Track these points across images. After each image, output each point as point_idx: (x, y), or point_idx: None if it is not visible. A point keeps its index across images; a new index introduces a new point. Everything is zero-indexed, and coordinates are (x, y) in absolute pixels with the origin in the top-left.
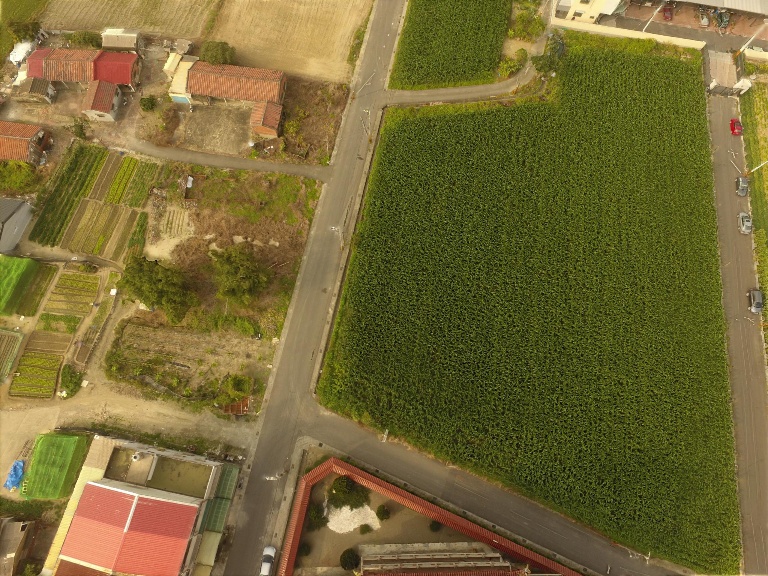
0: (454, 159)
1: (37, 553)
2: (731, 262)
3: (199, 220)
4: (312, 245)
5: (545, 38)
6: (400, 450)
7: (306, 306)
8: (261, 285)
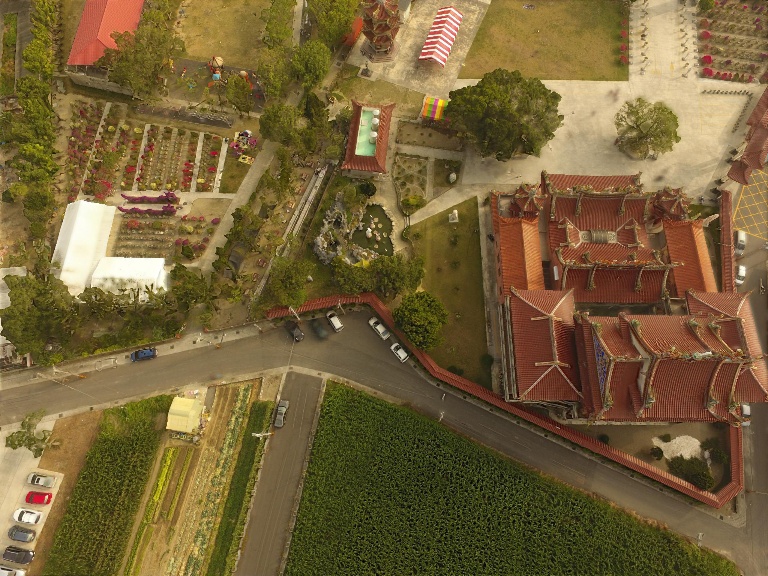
0: None
1: None
2: None
3: None
4: None
5: None
6: (642, 511)
7: None
8: None
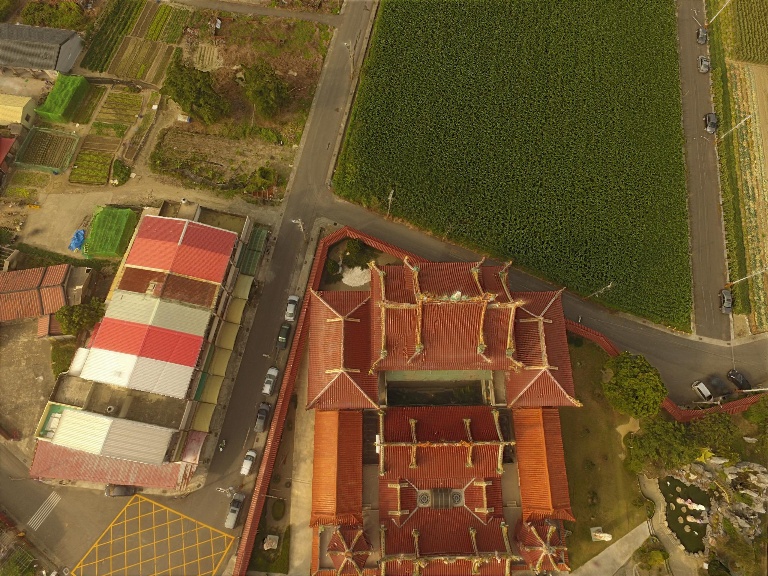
0: (449, 9)
1: (98, 296)
2: (691, 95)
3: (227, 54)
4: (326, 75)
5: None
6: (403, 229)
7: (321, 121)
8: (284, 91)
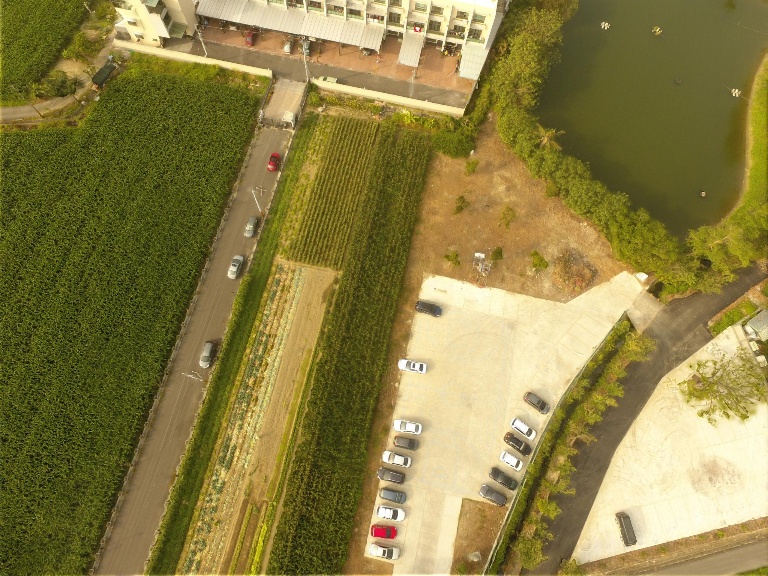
0: None
1: None
2: (205, 309)
3: None
4: None
5: (105, 60)
6: None
7: None
8: None
